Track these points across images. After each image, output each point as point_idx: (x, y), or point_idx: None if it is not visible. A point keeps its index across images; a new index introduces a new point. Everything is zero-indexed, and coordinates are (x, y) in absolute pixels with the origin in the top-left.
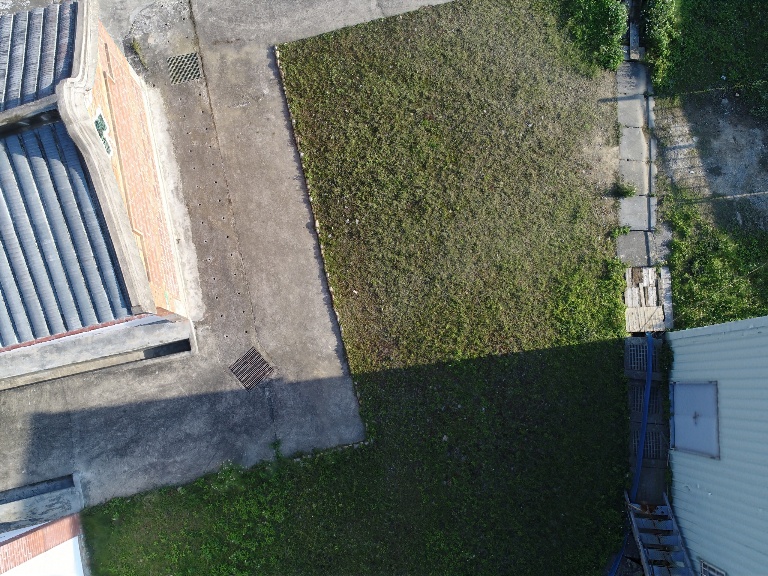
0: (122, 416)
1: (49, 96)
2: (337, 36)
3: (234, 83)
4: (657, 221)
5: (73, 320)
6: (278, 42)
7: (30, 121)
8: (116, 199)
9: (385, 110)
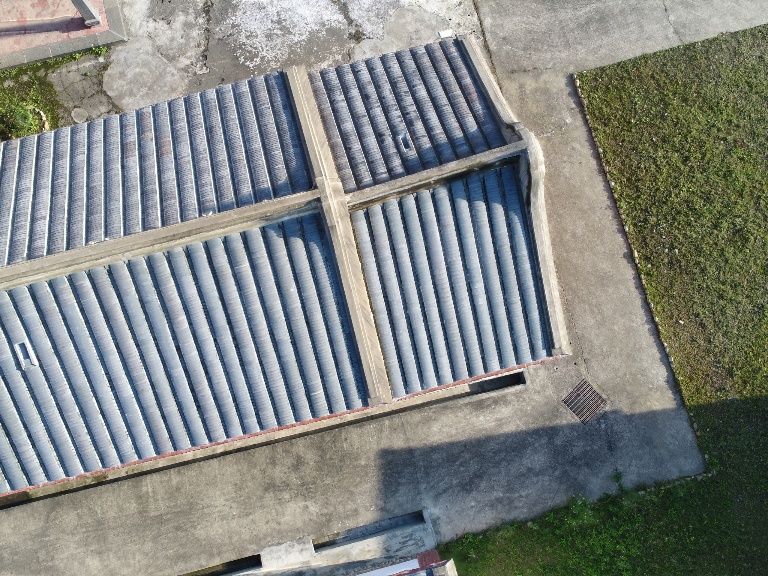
0: (463, 451)
1: (516, 142)
2: (636, 64)
3: (535, 112)
4: None
5: (494, 363)
6: (575, 70)
7: (483, 166)
8: (546, 242)
9: (694, 138)
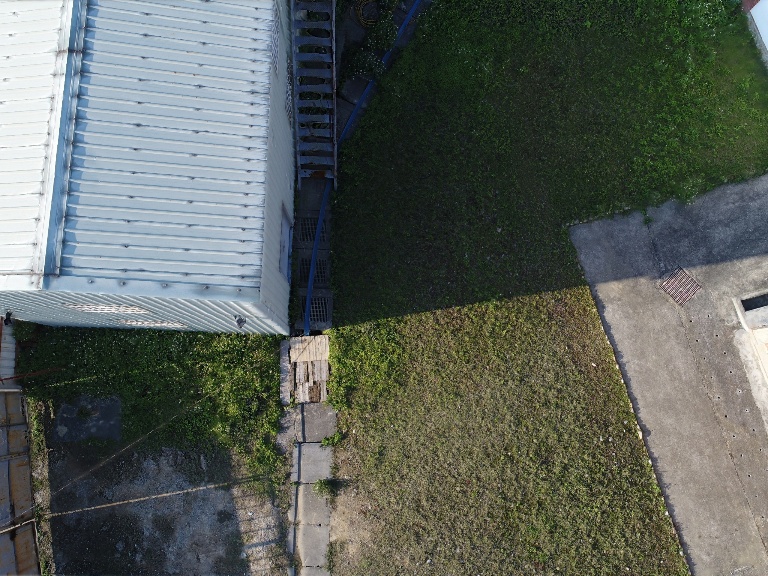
0: None
1: None
2: None
3: None
4: (292, 454)
5: None
6: None
7: None
8: None
9: (587, 572)
